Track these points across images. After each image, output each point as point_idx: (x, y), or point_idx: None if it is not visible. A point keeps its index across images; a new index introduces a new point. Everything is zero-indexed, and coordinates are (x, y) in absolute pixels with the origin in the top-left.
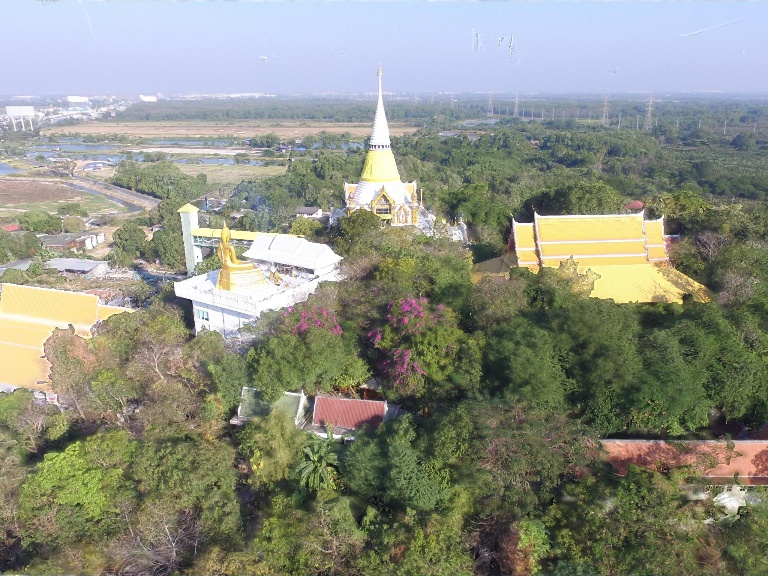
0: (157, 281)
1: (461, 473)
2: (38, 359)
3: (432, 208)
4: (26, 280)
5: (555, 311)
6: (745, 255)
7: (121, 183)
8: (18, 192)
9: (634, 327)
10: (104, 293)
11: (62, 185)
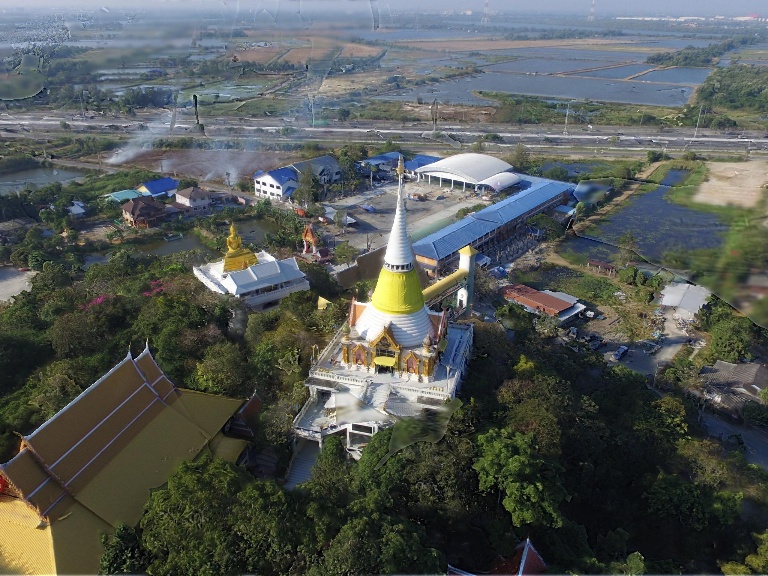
0: (646, 346)
1: None
2: None
3: None
4: (636, 283)
5: None
6: None
7: None
8: None
9: None
10: (557, 308)
11: None
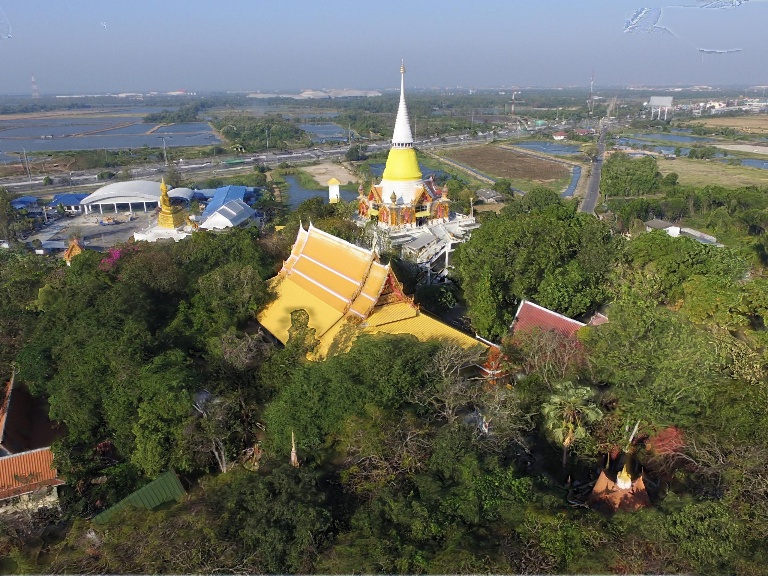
0: None
1: None
2: None
3: (480, 221)
4: None
5: None
6: (367, 339)
7: (601, 172)
8: (529, 169)
9: (111, 320)
10: None
11: (570, 168)
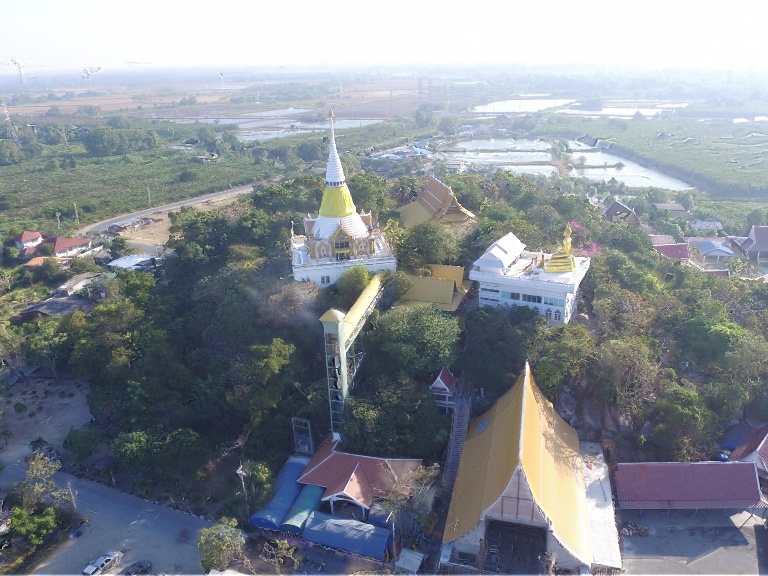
0: None
1: (643, 254)
2: (560, 475)
3: None
4: None
5: (564, 205)
6: None
7: None
8: None
9: None
10: None
11: None
